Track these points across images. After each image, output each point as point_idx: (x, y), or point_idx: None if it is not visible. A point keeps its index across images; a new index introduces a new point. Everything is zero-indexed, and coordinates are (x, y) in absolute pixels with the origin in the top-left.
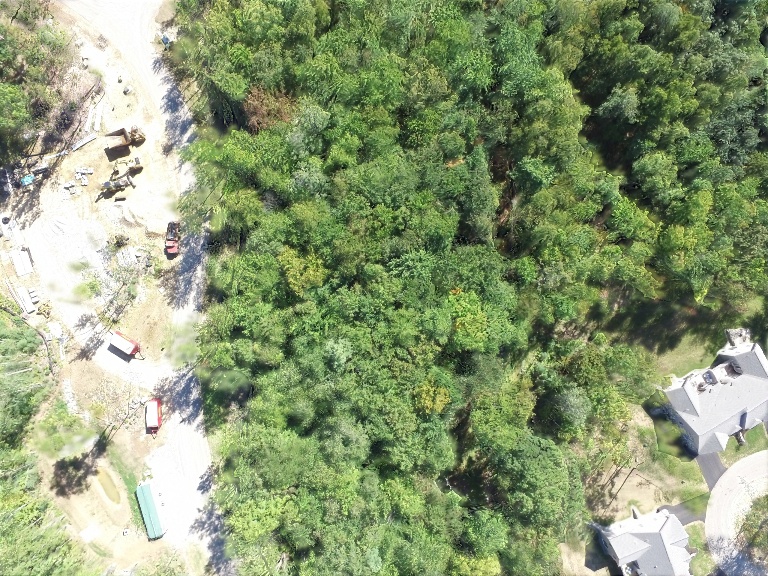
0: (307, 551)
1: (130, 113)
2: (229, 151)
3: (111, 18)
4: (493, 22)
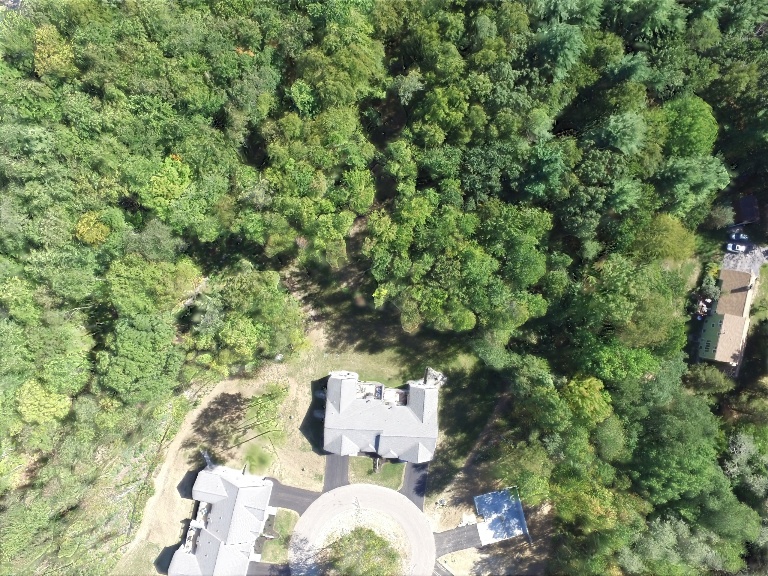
0: None
1: None
2: None
3: None
4: None
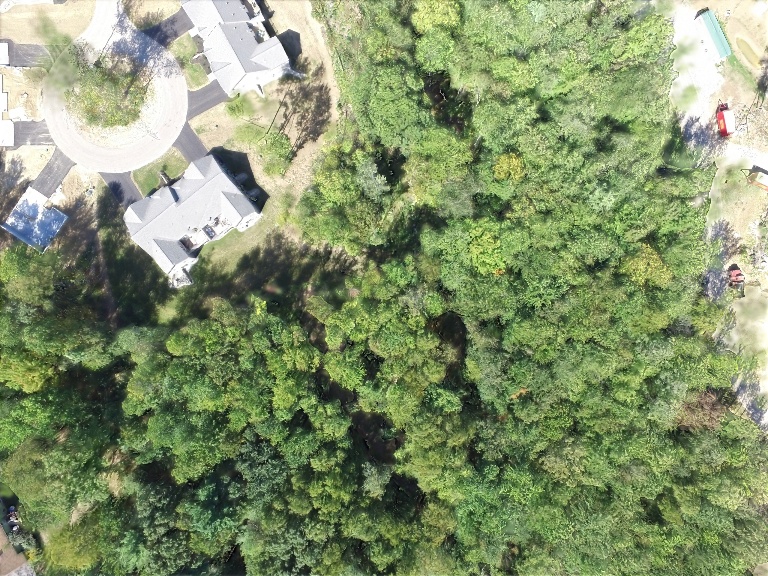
0: None
1: None
2: None
3: None
4: (506, 536)
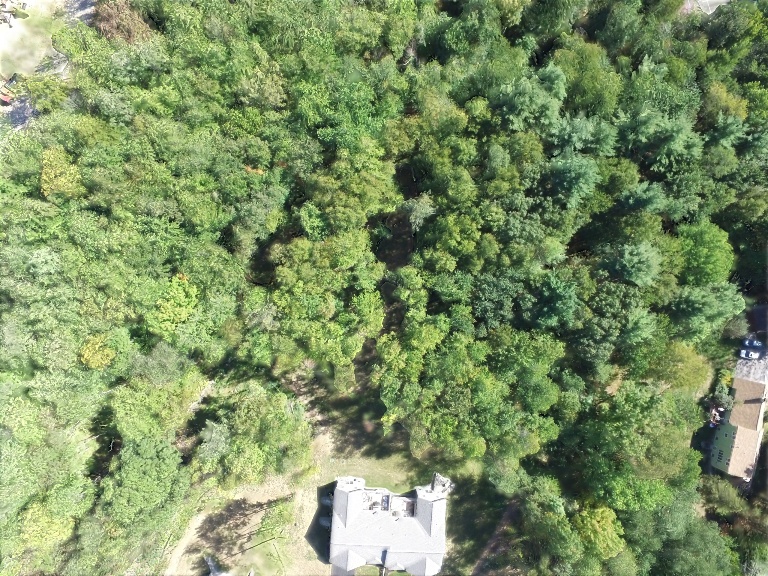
0: None
1: None
2: (57, 35)
3: None
4: (363, 72)
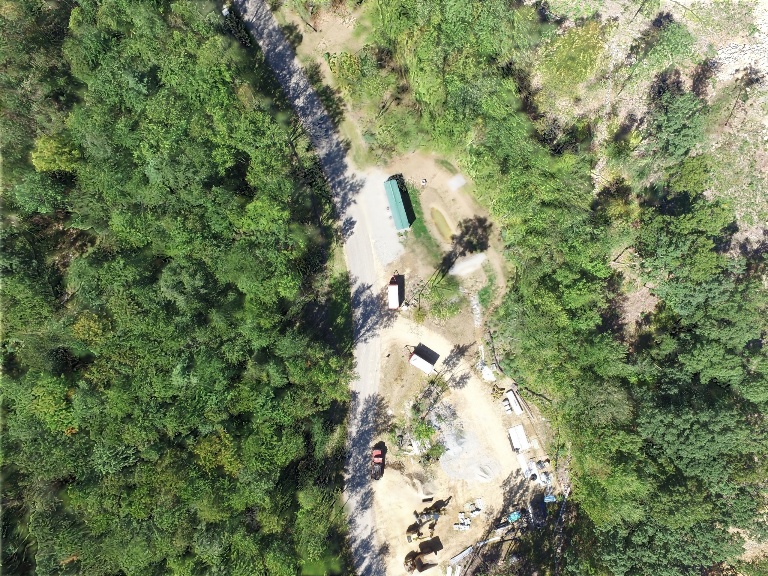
0: (229, 176)
1: None
2: (285, 574)
3: None
4: None
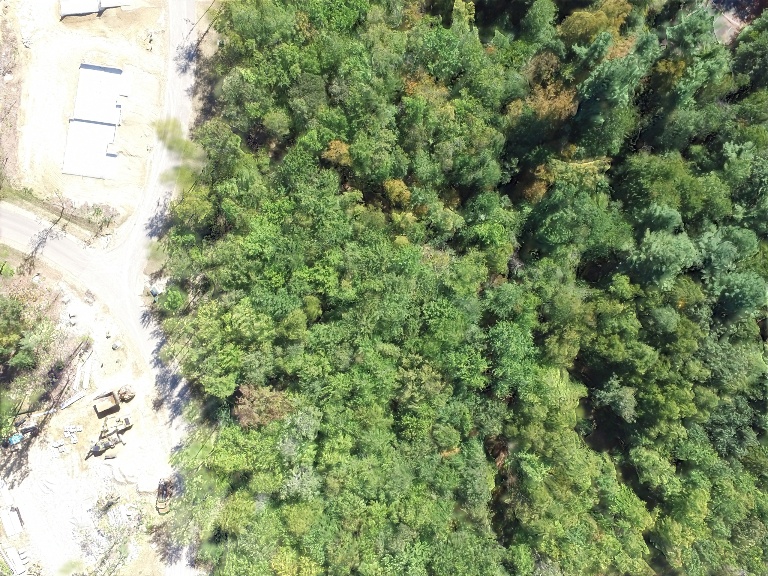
0: None
1: (119, 368)
2: (220, 463)
3: (98, 272)
4: (488, 307)
